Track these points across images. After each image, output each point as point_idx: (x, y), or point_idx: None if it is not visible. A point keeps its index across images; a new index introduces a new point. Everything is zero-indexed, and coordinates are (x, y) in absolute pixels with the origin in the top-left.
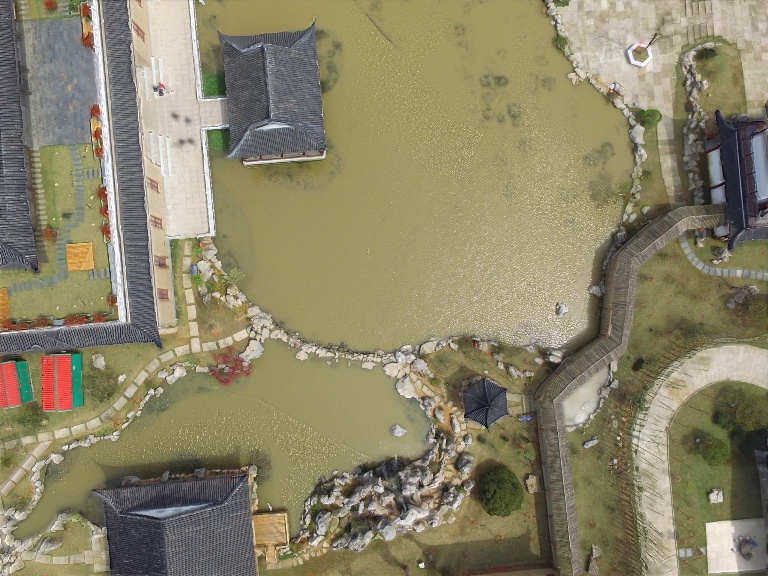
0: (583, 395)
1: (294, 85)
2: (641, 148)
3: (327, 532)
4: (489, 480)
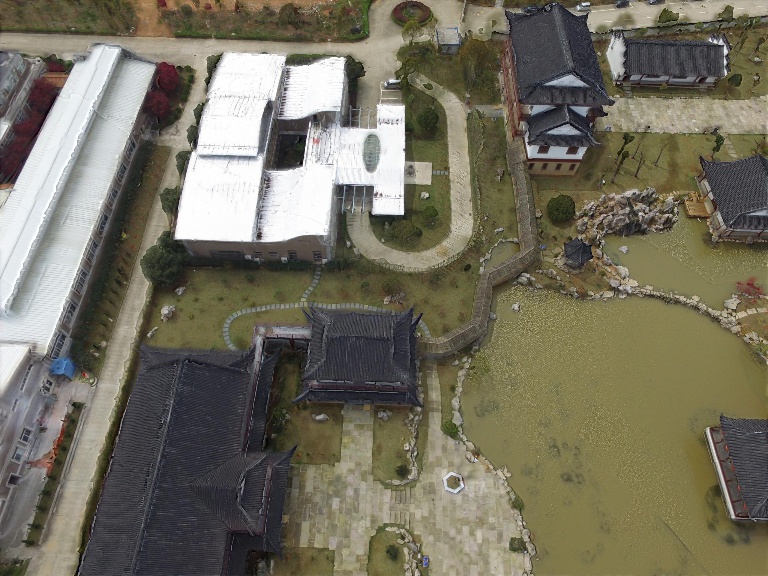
0: (501, 257)
1: (759, 465)
2: (457, 407)
3: (663, 203)
4: (571, 214)
